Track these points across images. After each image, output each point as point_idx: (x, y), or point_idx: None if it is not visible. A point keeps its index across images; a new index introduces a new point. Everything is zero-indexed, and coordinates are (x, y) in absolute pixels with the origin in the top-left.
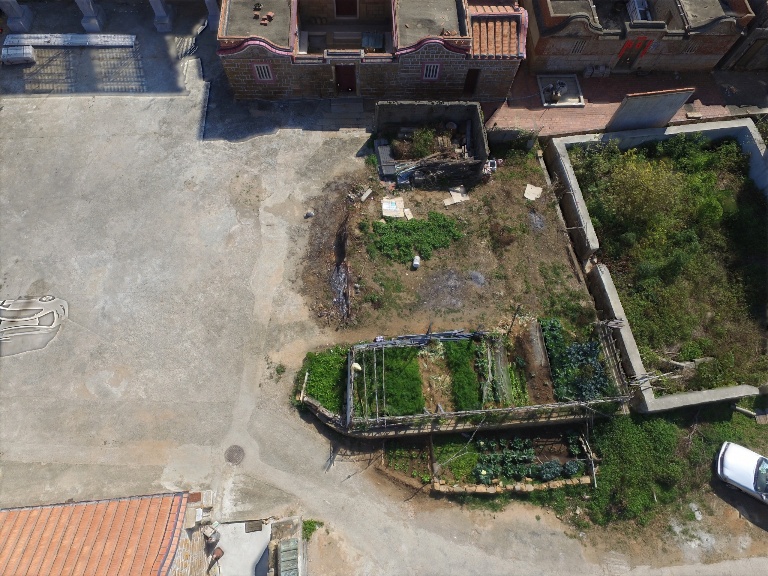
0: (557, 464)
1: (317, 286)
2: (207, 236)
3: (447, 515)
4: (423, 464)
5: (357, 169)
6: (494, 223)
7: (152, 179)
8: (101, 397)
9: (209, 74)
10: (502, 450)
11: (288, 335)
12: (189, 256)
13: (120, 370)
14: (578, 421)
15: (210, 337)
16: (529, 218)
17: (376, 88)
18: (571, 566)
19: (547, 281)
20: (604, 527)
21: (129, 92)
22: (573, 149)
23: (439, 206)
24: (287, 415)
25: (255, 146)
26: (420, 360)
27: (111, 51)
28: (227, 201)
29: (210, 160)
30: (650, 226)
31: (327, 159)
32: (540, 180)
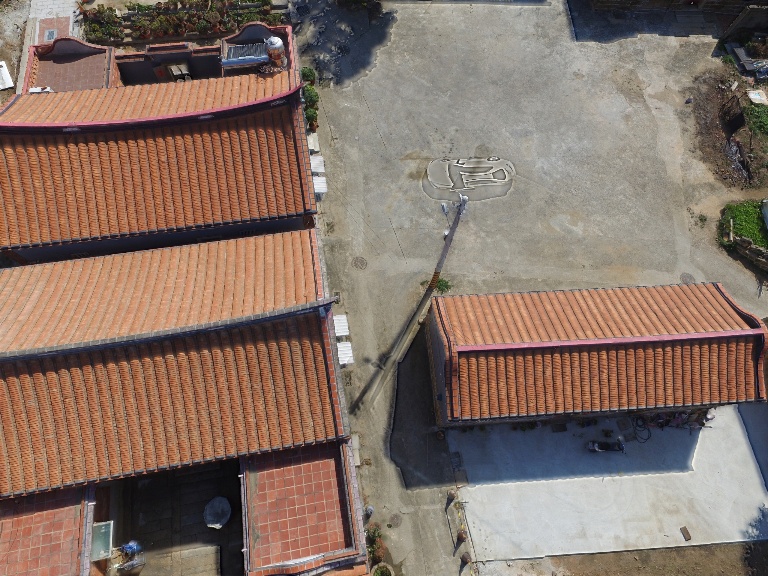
0: None
1: (715, 156)
2: (608, 115)
3: None
4: None
5: (717, 67)
6: None
7: (545, 70)
8: (567, 233)
9: None
10: None
11: (701, 192)
12: (599, 130)
13: (574, 214)
14: None
15: (638, 192)
16: None
17: (720, 1)
18: None
19: None
20: None
21: (499, 2)
22: None
23: None
24: (717, 253)
25: (623, 47)
26: None
27: None
28: (614, 89)
29: (588, 57)
30: None
31: (688, 58)
32: None
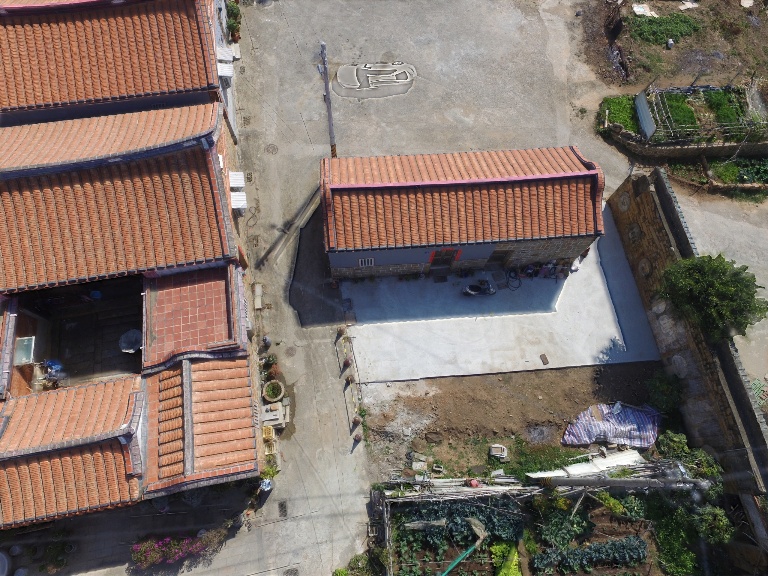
0: None
1: (598, 59)
2: (504, 27)
3: (722, 204)
4: (698, 174)
5: None
6: (722, 21)
7: None
8: (459, 123)
9: None
10: (754, 167)
11: (584, 89)
12: (495, 39)
13: (466, 108)
14: None
15: (526, 89)
16: (748, 18)
17: None
18: None
19: None
20: None
21: None
22: None
23: (676, 10)
24: (594, 139)
25: None
26: (687, 105)
27: None
28: (512, 5)
29: None
30: None
31: None
32: None
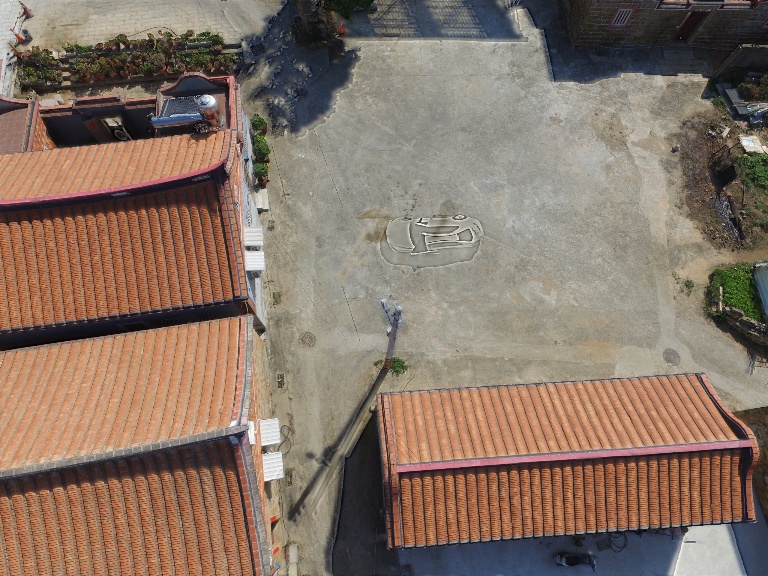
0: None
1: (703, 212)
2: (586, 166)
3: None
4: None
5: (707, 110)
6: None
7: (519, 115)
8: (538, 303)
9: (540, 23)
10: None
11: (688, 254)
12: (576, 183)
13: (546, 281)
14: None
15: (618, 254)
16: None
17: (711, 36)
18: None
19: None
20: None
21: (472, 37)
22: None
23: None
24: (705, 324)
25: (605, 88)
26: None
27: (442, 0)
28: (594, 136)
29: (567, 99)
30: None
31: (676, 100)
32: None
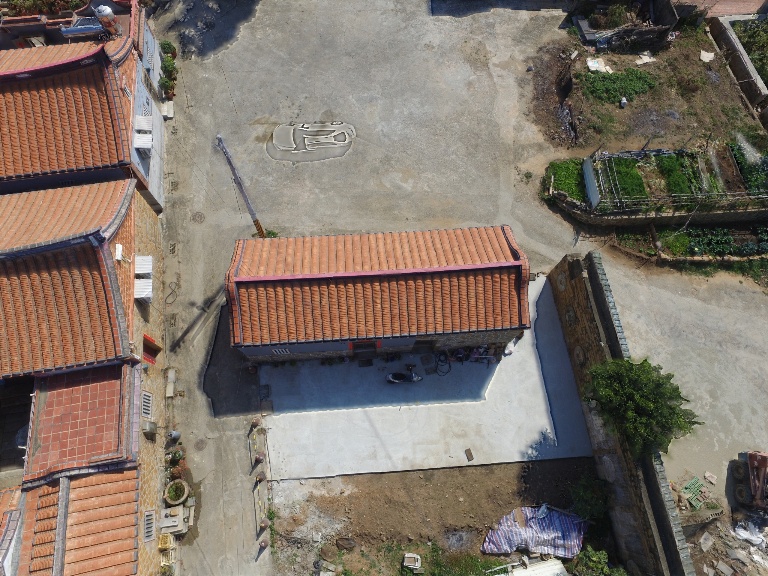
0: (753, 244)
1: (547, 118)
2: (451, 83)
3: (671, 278)
4: (646, 244)
5: (562, 38)
6: (680, 77)
7: (398, 42)
8: (396, 189)
9: None
10: (706, 236)
11: (530, 152)
12: (441, 96)
13: (405, 172)
14: (764, 217)
15: (470, 152)
16: (707, 74)
17: None
18: None
19: (729, 117)
20: None
21: None
22: (735, 25)
23: (632, 65)
24: (538, 207)
25: (475, 20)
26: (638, 170)
27: None
28: (461, 59)
29: (441, 30)
30: None
31: (536, 30)
32: (711, 48)
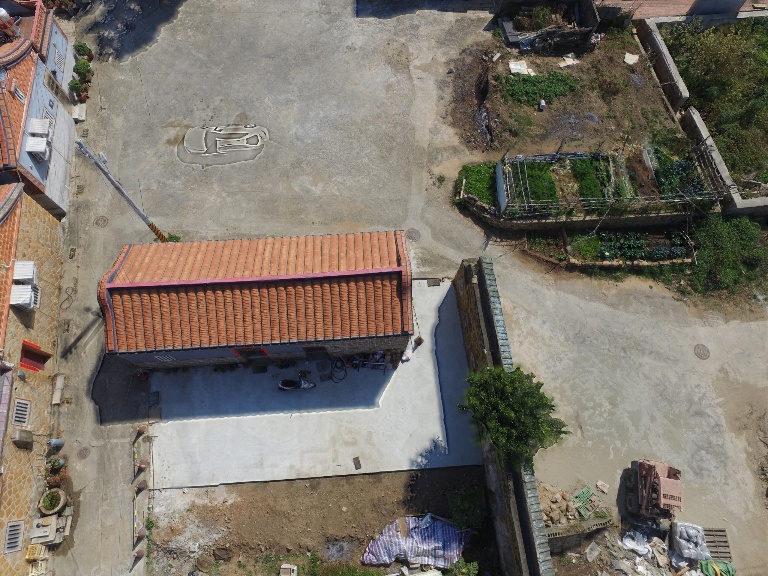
0: (664, 249)
1: (464, 121)
2: (370, 85)
3: (580, 283)
4: (558, 249)
5: (486, 39)
6: (602, 79)
7: (320, 44)
8: (304, 193)
9: None
10: (619, 241)
11: (444, 155)
12: (358, 99)
13: (316, 176)
14: (678, 222)
15: (383, 155)
16: (630, 77)
17: None
18: (679, 319)
19: (649, 120)
20: (703, 294)
21: None
22: (662, 27)
23: (555, 67)
24: (449, 211)
25: (400, 22)
26: (552, 173)
27: None
28: (383, 61)
29: (365, 32)
30: (729, 84)
31: (460, 32)
32: (636, 50)
